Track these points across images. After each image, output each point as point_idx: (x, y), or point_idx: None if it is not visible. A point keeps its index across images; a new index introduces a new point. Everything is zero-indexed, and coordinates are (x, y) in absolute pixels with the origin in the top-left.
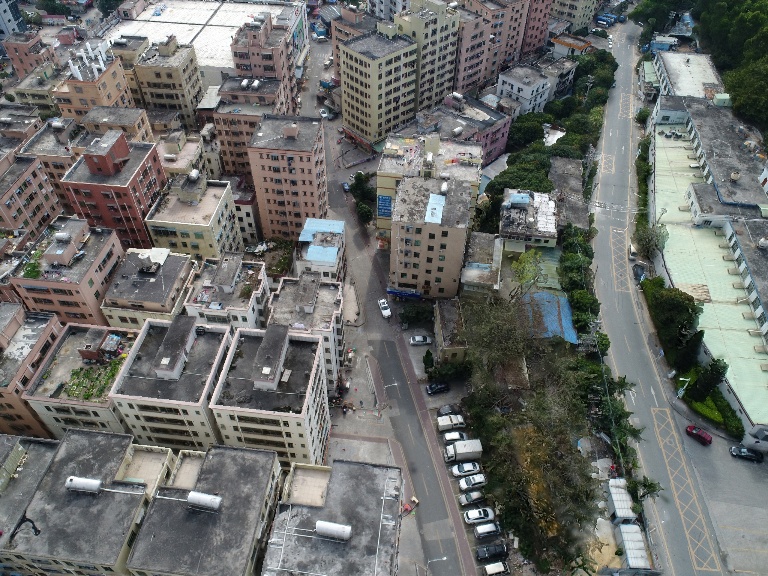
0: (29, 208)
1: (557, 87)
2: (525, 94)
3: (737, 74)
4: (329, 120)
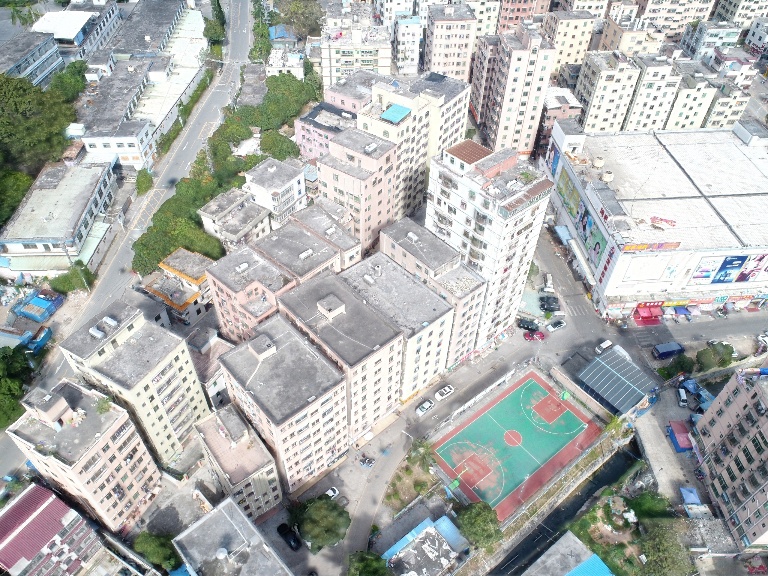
0: (564, 2)
1: None
2: None
3: (44, 133)
4: None
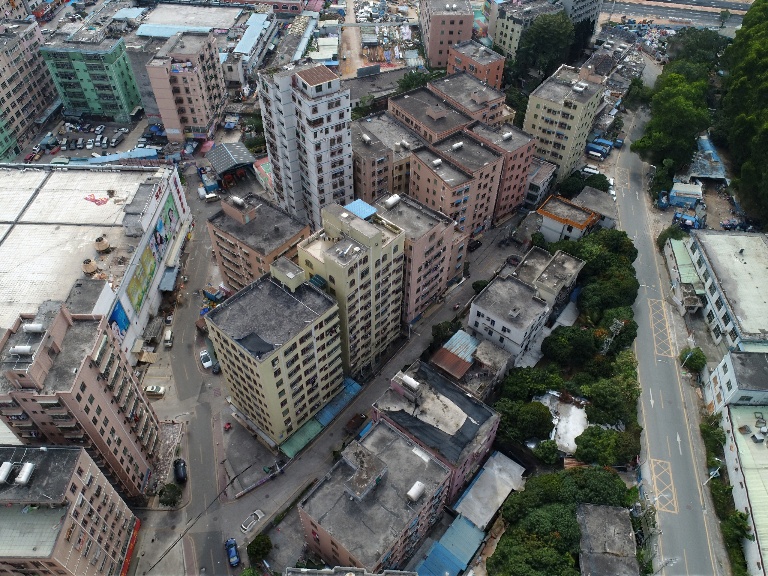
0: None
1: (556, 299)
2: (514, 337)
3: None
4: (214, 373)
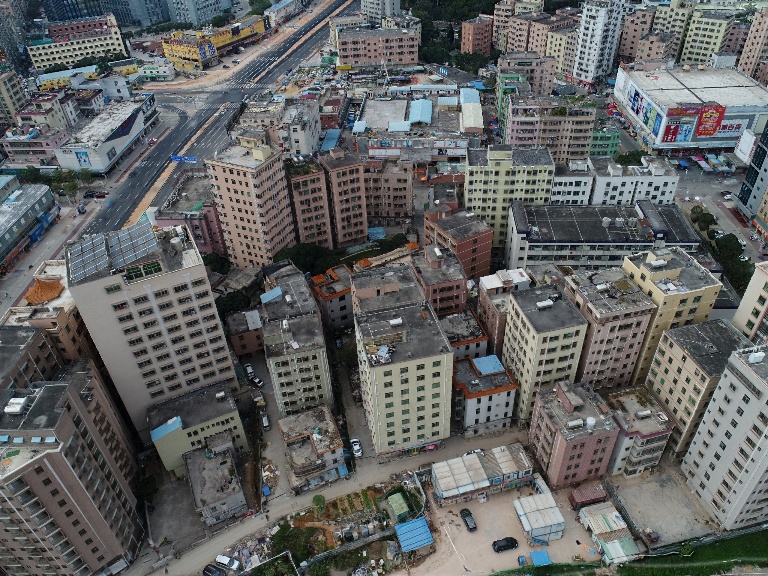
0: None
1: None
2: None
3: None
4: None
